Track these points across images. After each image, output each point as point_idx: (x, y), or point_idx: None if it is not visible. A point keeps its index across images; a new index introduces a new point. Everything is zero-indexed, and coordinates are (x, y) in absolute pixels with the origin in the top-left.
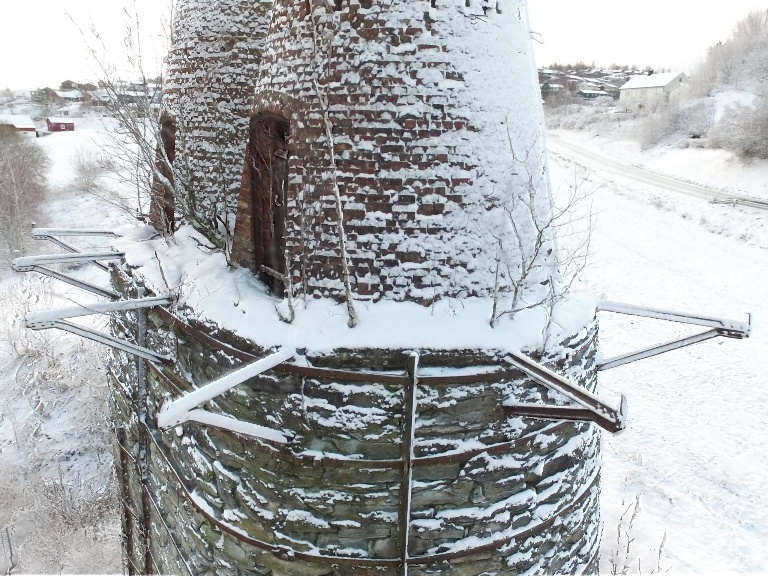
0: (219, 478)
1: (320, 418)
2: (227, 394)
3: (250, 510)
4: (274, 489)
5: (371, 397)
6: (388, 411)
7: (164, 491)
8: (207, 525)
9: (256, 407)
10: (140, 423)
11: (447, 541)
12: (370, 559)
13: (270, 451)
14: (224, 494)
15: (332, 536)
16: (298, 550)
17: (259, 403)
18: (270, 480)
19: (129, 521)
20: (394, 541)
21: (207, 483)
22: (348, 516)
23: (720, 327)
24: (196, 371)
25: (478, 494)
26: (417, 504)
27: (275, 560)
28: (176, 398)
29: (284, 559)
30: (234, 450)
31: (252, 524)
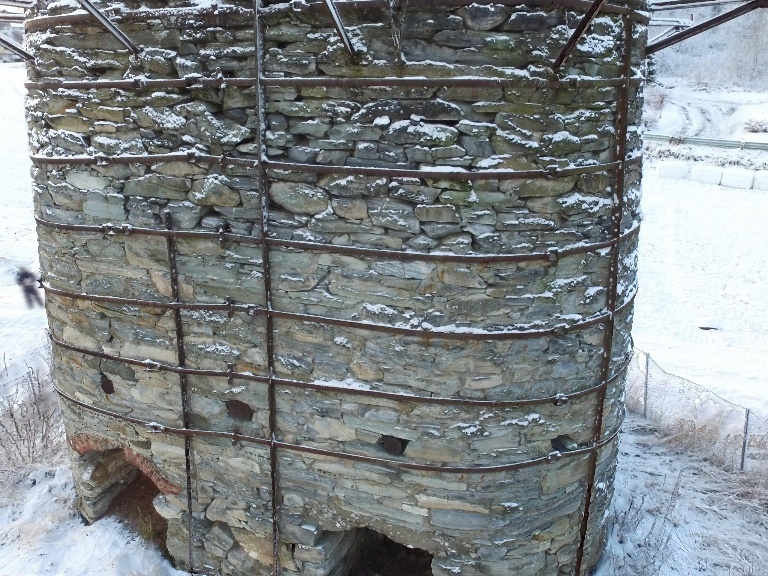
0: (474, 131)
1: (578, 45)
2: (482, 45)
3: (515, 147)
4: (540, 118)
5: (605, 27)
6: (614, 39)
7: (326, 216)
8: (449, 191)
9: (522, 46)
10: (261, 163)
11: (629, 151)
12: (605, 164)
13: (540, 82)
14: (480, 145)
15: (578, 153)
16: (561, 168)
17: (525, 41)
18: (535, 112)
19: (179, 330)
20: (612, 150)
21: (452, 146)
22: (590, 132)
23: (679, 25)
24: (415, 45)
25: (637, 116)
26: (617, 122)
27: (540, 184)
28: (363, 94)
29: (550, 179)
30: (490, 99)
31: (516, 160)
